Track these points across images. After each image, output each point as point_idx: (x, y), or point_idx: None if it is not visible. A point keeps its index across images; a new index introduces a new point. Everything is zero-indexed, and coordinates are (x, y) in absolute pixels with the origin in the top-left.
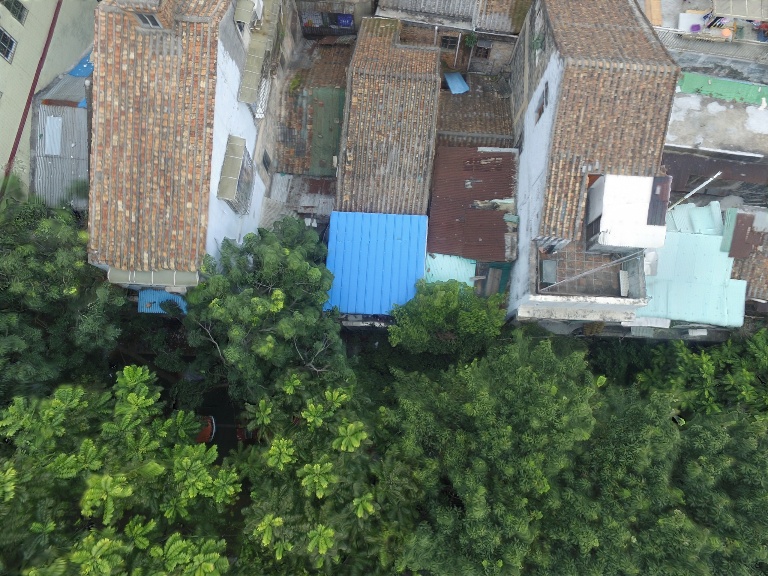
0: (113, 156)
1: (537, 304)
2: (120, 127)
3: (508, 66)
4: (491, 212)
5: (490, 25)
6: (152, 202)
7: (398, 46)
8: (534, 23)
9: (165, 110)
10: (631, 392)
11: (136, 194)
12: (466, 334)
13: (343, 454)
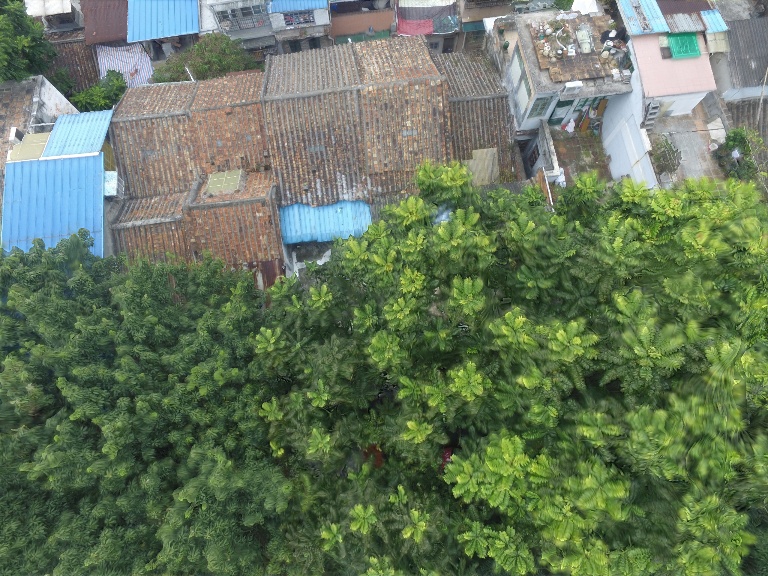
0: None
1: None
2: None
3: None
4: None
5: None
6: None
7: None
8: None
9: None
10: None
11: None
12: None
13: None
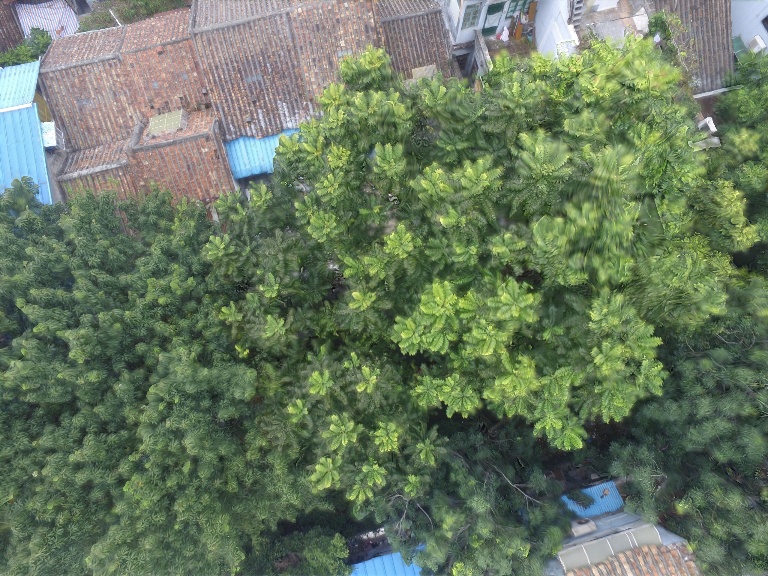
0: None
1: None
2: None
3: None
4: None
5: None
6: None
7: None
8: None
9: None
10: (76, 573)
11: None
12: (264, 575)
13: (330, 451)
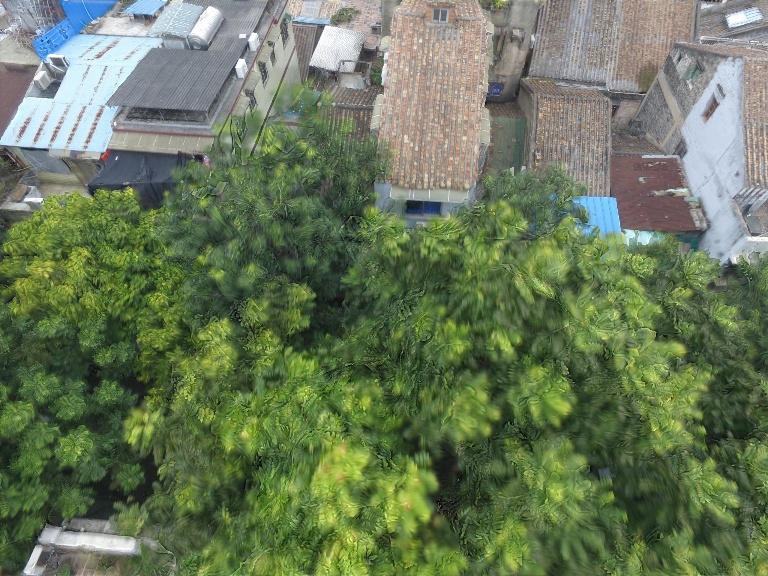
0: (402, 104)
1: (750, 251)
2: (409, 85)
3: (637, 118)
4: (670, 197)
5: (621, 87)
6: (433, 136)
7: (563, 88)
8: (675, 69)
9: (446, 74)
10: None
11: (420, 130)
12: None
13: None
